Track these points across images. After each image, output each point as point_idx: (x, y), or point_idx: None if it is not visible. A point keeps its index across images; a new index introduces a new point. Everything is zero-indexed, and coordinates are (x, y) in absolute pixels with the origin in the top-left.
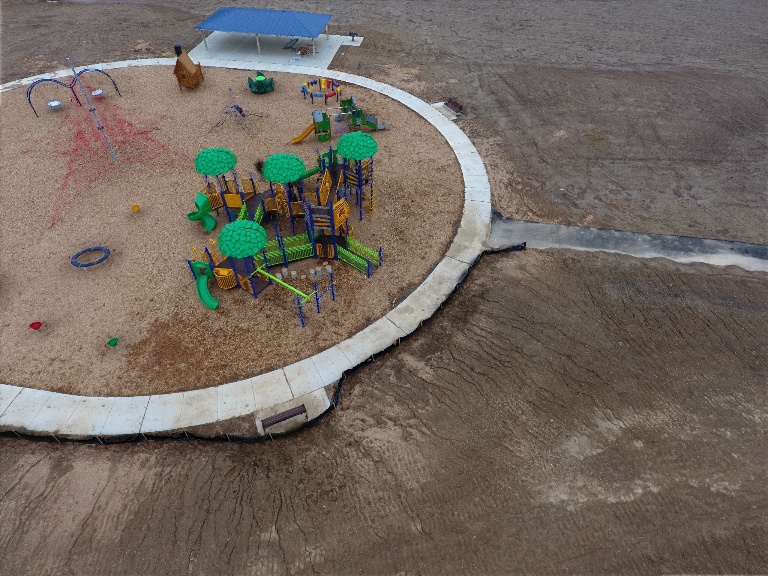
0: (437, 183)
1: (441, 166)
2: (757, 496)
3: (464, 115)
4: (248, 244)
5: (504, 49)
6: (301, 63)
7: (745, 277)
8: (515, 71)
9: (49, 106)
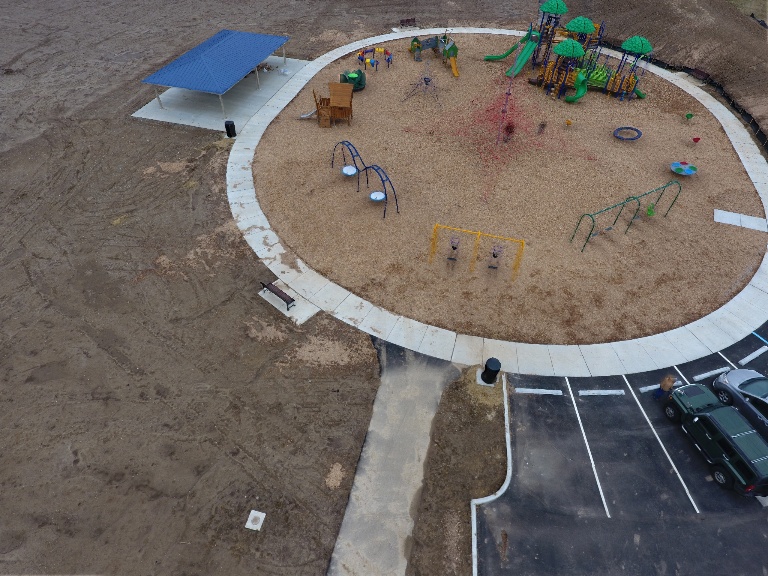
0: (503, 40)
1: (483, 37)
2: None
3: (414, 25)
4: None
5: (292, 4)
6: (292, 70)
7: None
8: (348, 3)
9: None
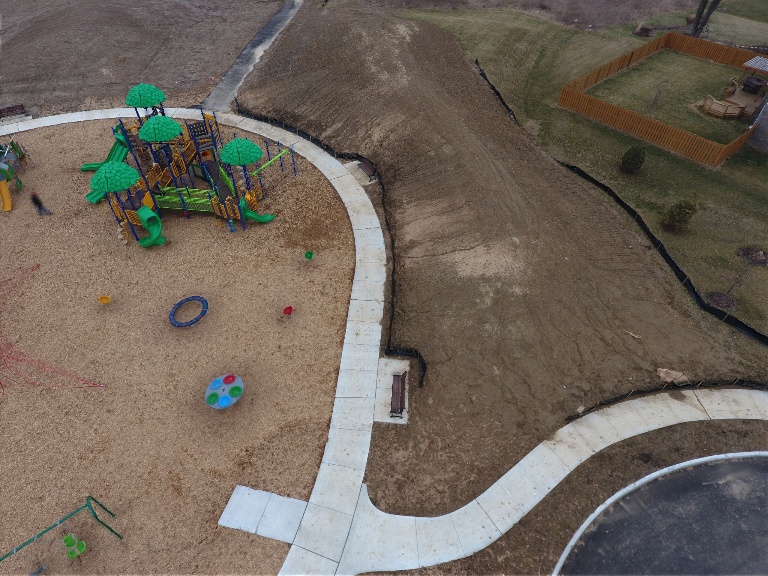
0: None
1: None
2: (399, 47)
3: (28, 112)
4: None
5: None
6: None
7: (273, 50)
8: None
9: None
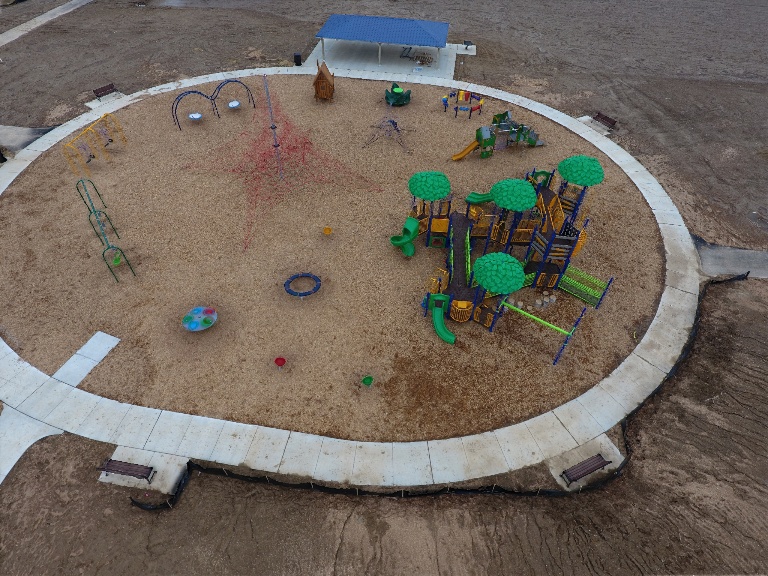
0: (621, 204)
1: (617, 186)
2: None
3: (616, 130)
4: (514, 279)
5: (622, 59)
6: (424, 73)
7: None
8: (648, 83)
9: (188, 118)
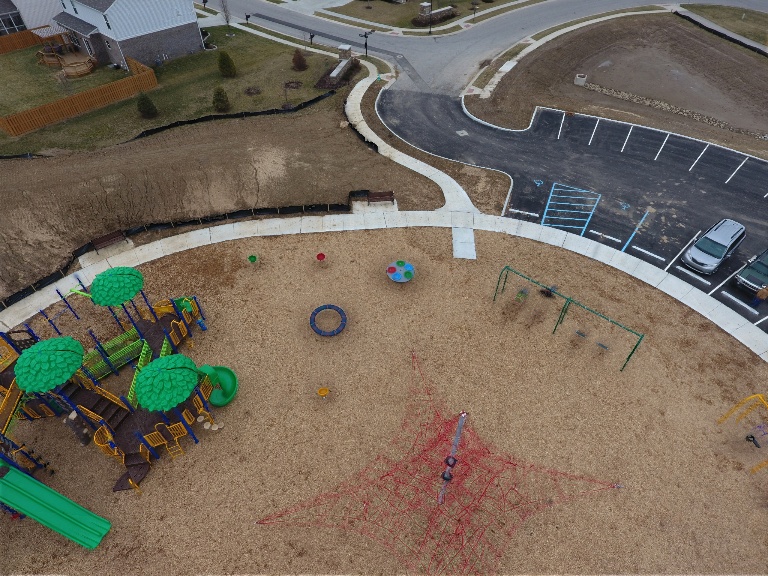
0: None
1: None
2: None
3: None
4: None
5: None
6: None
7: None
8: None
9: None
